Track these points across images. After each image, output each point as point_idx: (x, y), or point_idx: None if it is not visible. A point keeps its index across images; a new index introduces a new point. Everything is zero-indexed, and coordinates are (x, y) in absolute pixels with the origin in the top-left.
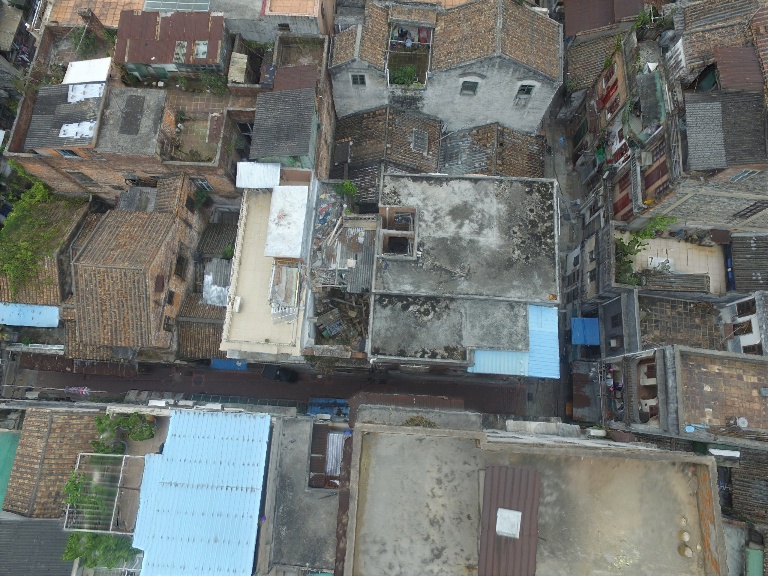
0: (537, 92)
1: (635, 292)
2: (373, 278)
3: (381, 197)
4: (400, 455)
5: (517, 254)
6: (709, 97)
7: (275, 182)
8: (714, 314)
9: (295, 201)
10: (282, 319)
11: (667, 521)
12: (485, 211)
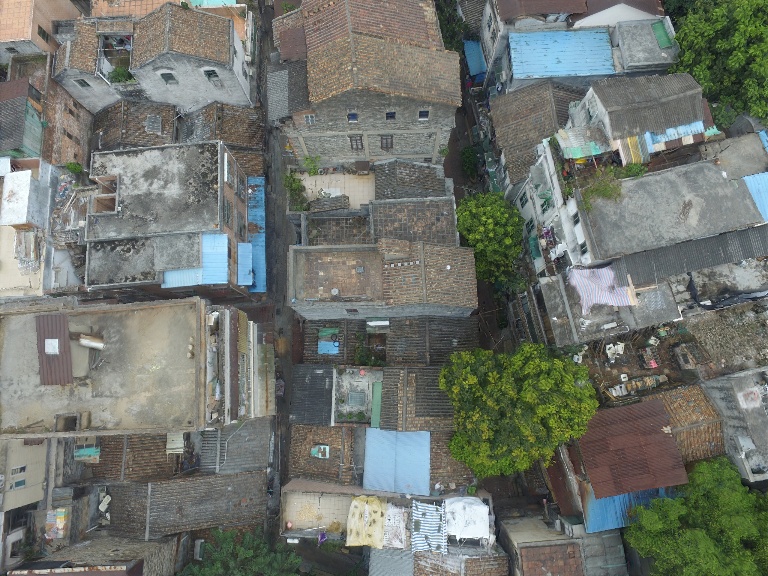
0: (221, 74)
1: (301, 216)
2: (85, 231)
3: (92, 171)
4: (24, 328)
5: (192, 199)
6: (281, 67)
7: (7, 171)
8: (367, 224)
9: (21, 182)
10: (27, 271)
11: (184, 341)
12: (169, 171)
